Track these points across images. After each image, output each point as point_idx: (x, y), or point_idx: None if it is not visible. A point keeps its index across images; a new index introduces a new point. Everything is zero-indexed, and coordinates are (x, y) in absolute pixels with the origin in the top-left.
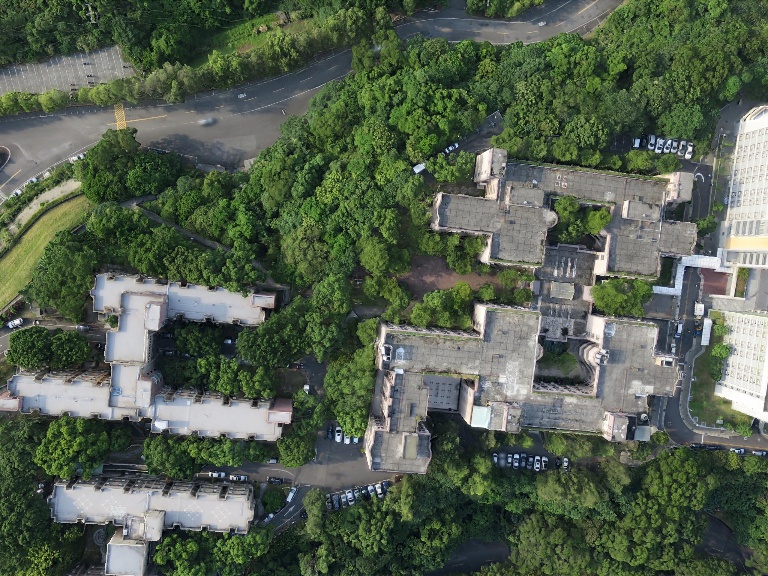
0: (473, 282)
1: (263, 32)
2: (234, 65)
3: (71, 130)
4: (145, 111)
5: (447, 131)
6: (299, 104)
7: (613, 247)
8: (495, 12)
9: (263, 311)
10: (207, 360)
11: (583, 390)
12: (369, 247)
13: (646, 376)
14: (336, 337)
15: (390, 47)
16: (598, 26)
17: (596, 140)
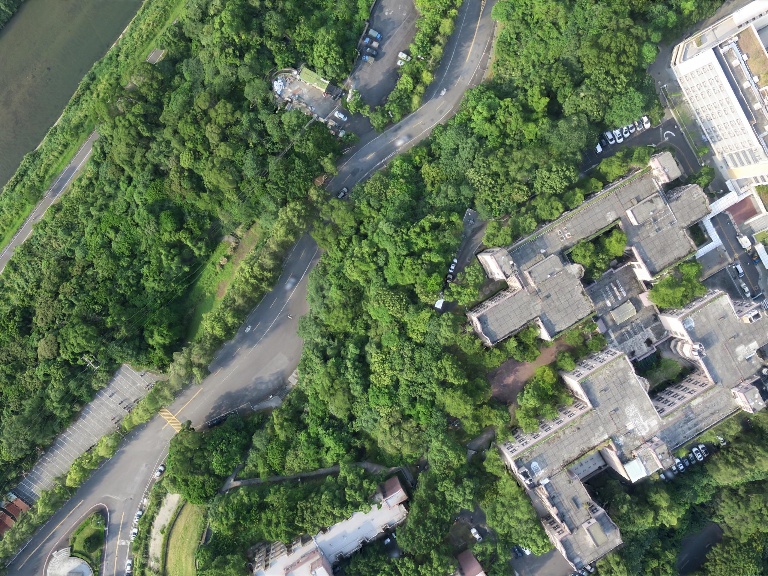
0: (546, 356)
1: (225, 264)
2: (230, 321)
3: (138, 454)
4: (183, 397)
5: (442, 260)
6: (297, 302)
7: (643, 254)
8: (400, 115)
9: (400, 505)
10: (385, 572)
11: (698, 381)
12: (449, 400)
13: (744, 338)
14: (474, 487)
15: (341, 215)
16: (490, 59)
17: (568, 180)
